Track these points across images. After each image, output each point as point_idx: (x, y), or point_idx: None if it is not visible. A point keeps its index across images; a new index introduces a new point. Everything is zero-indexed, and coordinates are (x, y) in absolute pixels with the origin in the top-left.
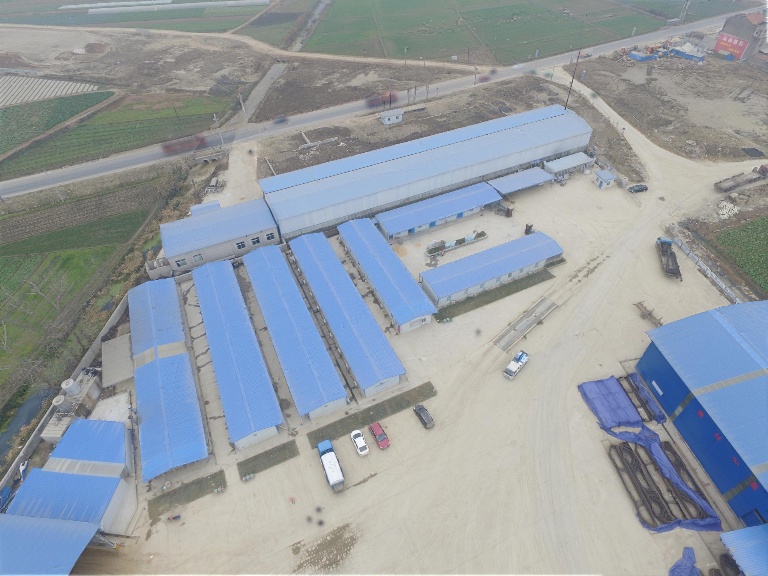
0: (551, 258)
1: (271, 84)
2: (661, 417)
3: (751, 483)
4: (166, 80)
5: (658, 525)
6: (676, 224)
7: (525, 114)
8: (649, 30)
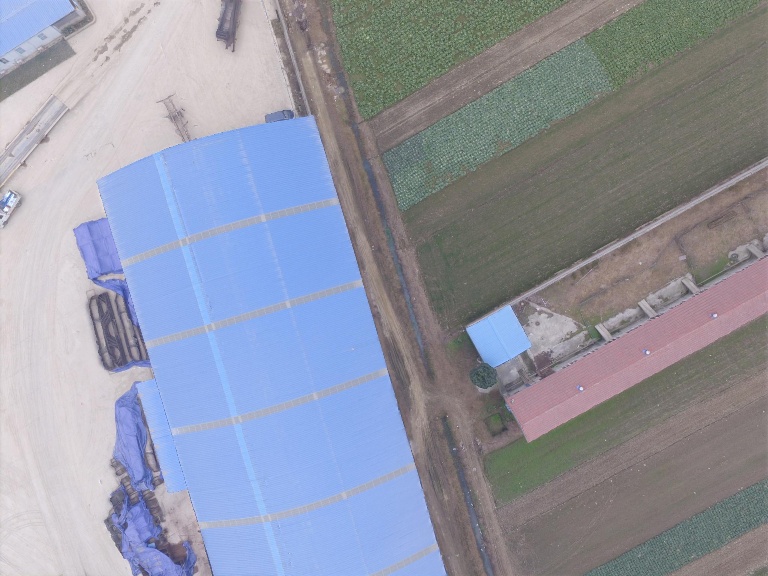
0: (62, 21)
1: None
2: None
3: None
4: None
5: (115, 368)
6: None
7: None
8: None
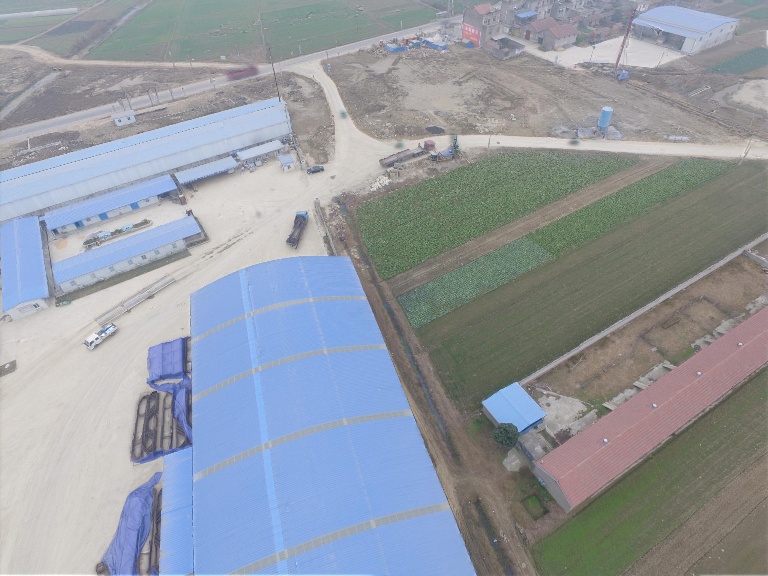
0: (190, 238)
1: (31, 93)
2: None
3: None
4: None
5: (142, 457)
6: (330, 199)
7: (241, 108)
8: (422, 23)
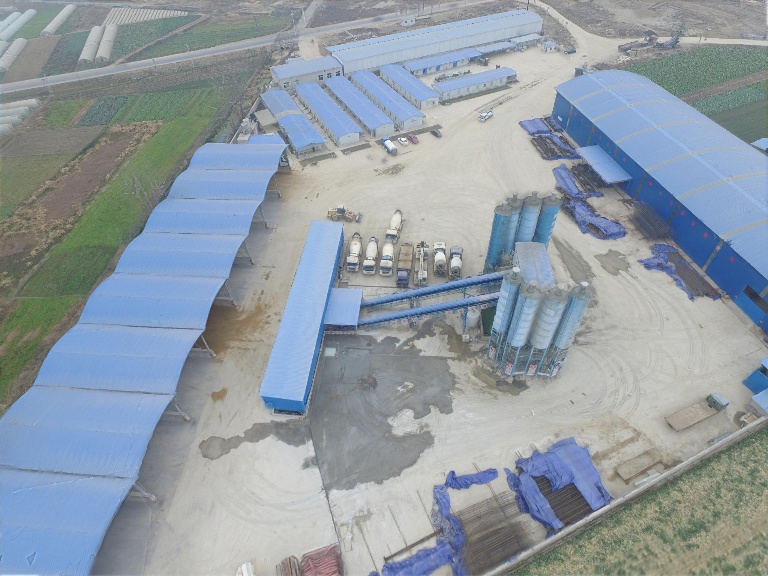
0: (510, 78)
1: (316, 9)
2: (560, 130)
3: (592, 131)
4: (237, 8)
5: (550, 158)
6: (590, 66)
7: (499, 14)
8: None
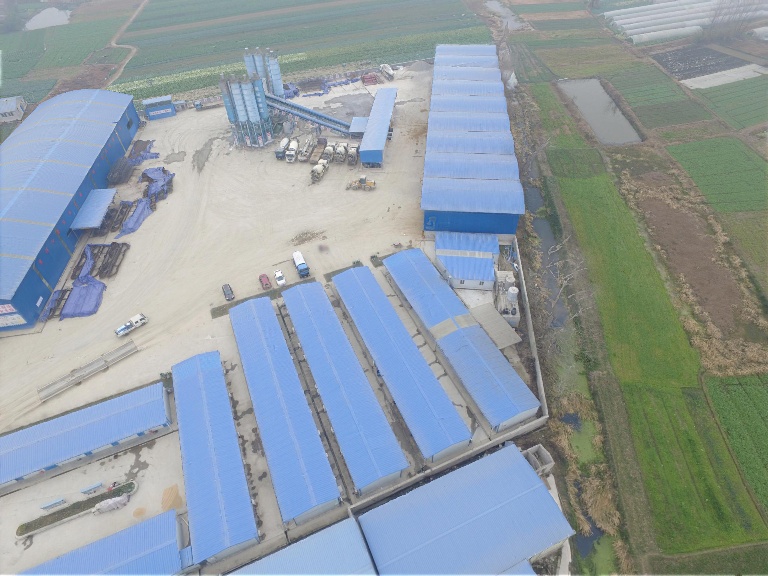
0: None
1: None
2: None
3: None
4: None
5: None
6: None
7: None
8: None
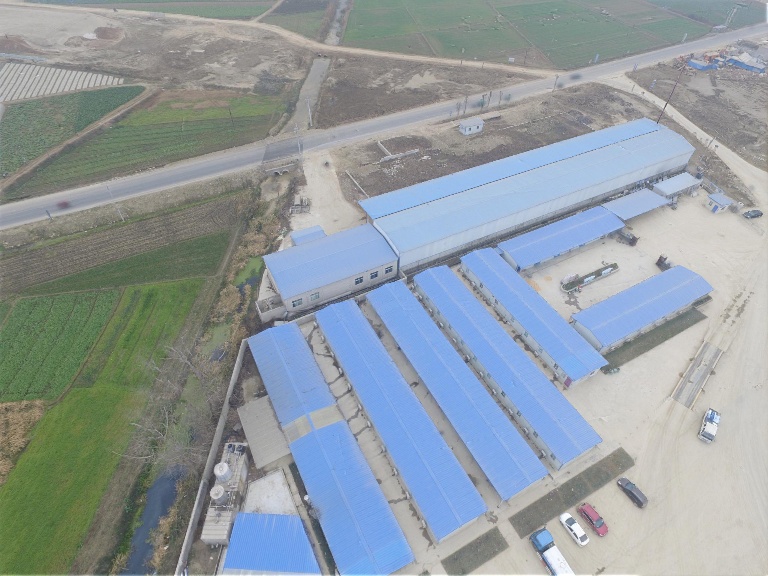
0: None
1: (321, 83)
2: None
3: None
4: (201, 74)
5: None
6: None
7: (617, 128)
8: (695, 36)
